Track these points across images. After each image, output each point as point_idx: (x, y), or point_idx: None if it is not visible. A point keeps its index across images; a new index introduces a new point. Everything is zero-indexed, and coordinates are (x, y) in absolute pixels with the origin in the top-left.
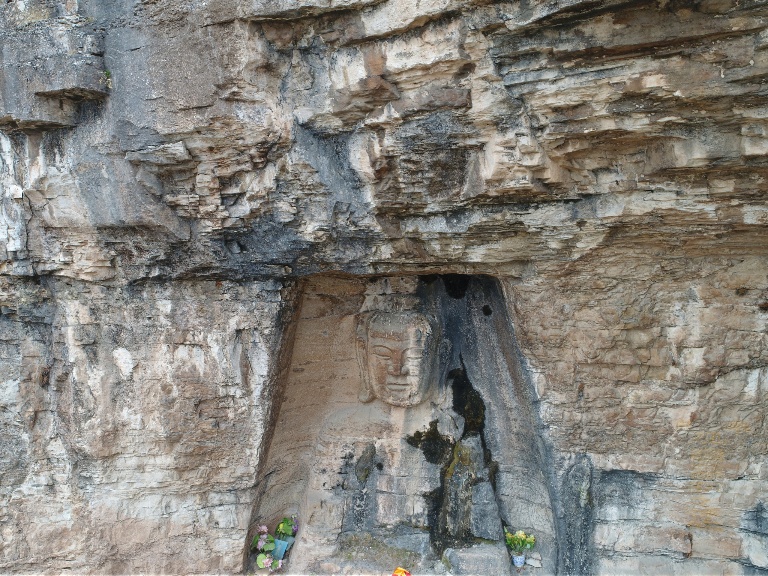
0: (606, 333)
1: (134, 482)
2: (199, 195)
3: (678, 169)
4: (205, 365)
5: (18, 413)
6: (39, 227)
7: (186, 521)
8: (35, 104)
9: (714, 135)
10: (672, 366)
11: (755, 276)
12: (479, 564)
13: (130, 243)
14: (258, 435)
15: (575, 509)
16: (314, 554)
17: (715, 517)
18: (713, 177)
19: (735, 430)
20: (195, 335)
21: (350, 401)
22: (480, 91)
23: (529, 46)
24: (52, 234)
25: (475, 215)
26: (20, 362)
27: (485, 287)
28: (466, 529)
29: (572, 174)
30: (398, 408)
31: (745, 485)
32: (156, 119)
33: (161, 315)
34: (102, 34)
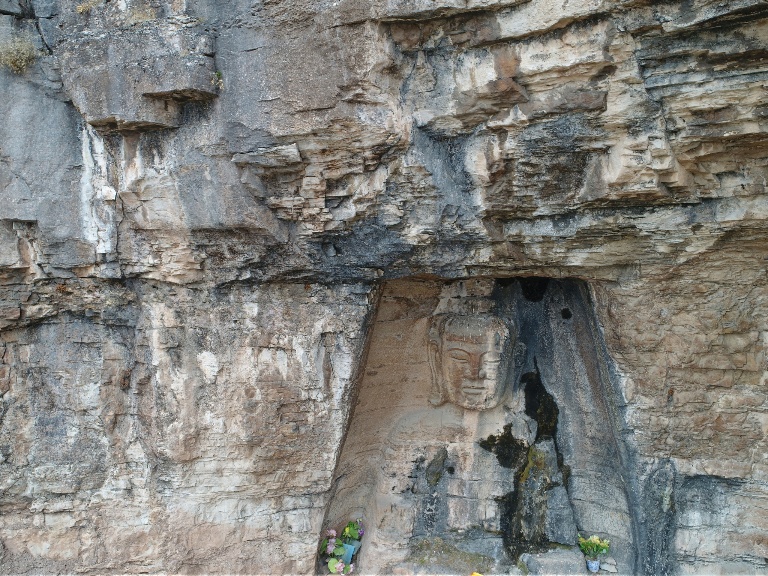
0: (703, 338)
1: (212, 486)
2: (303, 198)
3: None
4: (288, 368)
5: (98, 416)
6: (130, 229)
7: (260, 525)
8: (142, 105)
9: None
10: (767, 371)
11: None
12: (558, 569)
13: (224, 246)
14: (336, 439)
15: (657, 514)
16: (386, 559)
17: None
18: None
19: None
20: (280, 338)
21: (420, 404)
22: (618, 94)
23: (682, 48)
24: (142, 236)
25: (585, 219)
26: (101, 365)
27: (566, 290)
28: (541, 534)
29: (696, 178)
30: (471, 412)
31: None
32: (270, 121)
33: (247, 318)
34: (214, 34)
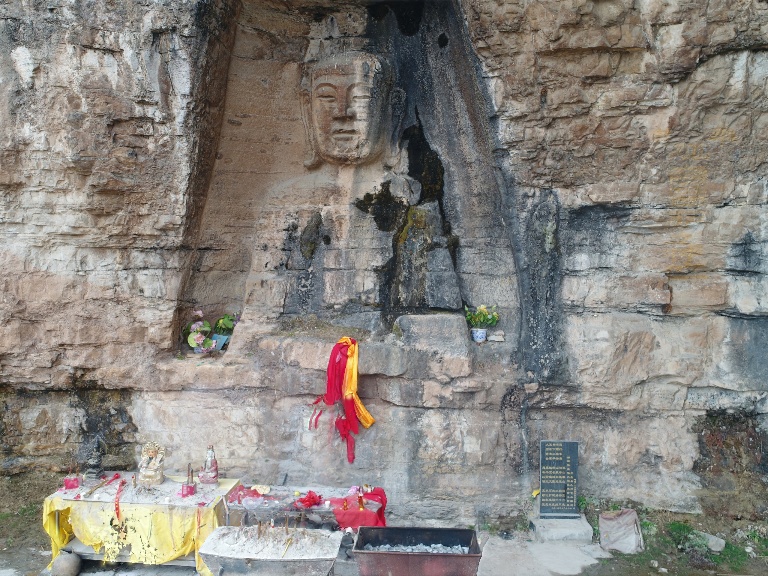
0: (570, 4)
1: (43, 225)
2: None
3: None
4: (118, 78)
5: None
6: None
7: (105, 283)
8: None
9: None
10: (647, 52)
11: None
12: (432, 326)
13: None
14: (183, 175)
15: (540, 256)
16: (251, 331)
17: (697, 256)
18: None
19: (720, 140)
20: (105, 36)
21: (296, 172)
22: None
23: None
24: None
25: None
26: None
27: (440, 10)
28: (420, 298)
29: None
30: (346, 168)
31: (731, 214)
32: None
33: (64, 6)
34: None
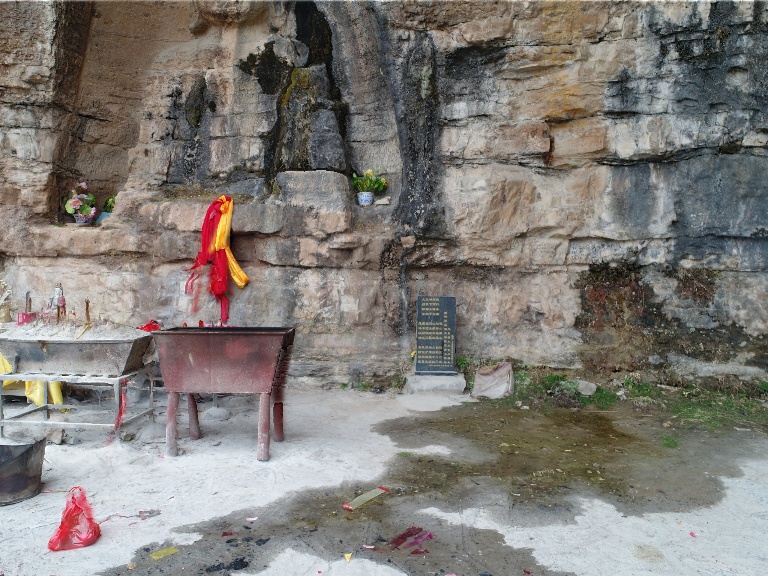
0: None
1: None
2: None
3: None
4: None
5: None
6: None
7: None
8: None
9: None
10: None
11: None
12: (309, 181)
13: None
14: (49, 22)
15: (416, 103)
16: (131, 197)
17: (575, 98)
18: None
19: None
20: None
21: (183, 40)
22: None
23: None
24: None
25: None
26: None
27: None
28: (303, 160)
29: None
30: (229, 28)
31: (607, 50)
32: None
33: None
34: None
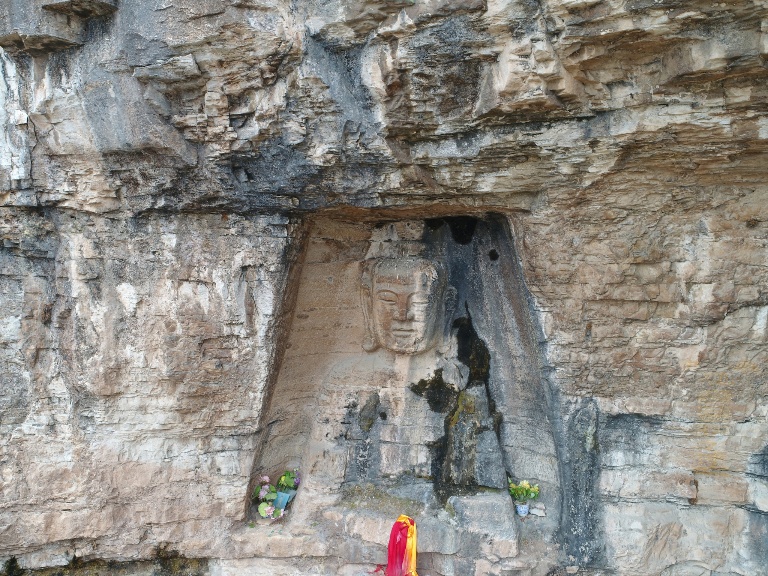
0: (615, 267)
1: (136, 424)
2: (207, 116)
3: (695, 75)
4: (209, 303)
5: (19, 350)
6: (43, 155)
7: (188, 466)
8: (42, 18)
9: (733, 33)
10: (681, 303)
11: (766, 207)
12: (483, 510)
13: (136, 170)
14: (262, 378)
15: (581, 454)
16: (316, 503)
17: (721, 461)
18: (730, 84)
19: (743, 370)
20: (200, 271)
21: (354, 351)
22: None
23: None
24: (57, 163)
25: (486, 137)
26: (22, 298)
27: (492, 231)
28: (470, 477)
29: (586, 88)
30: (403, 356)
31: (752, 428)
32: (166, 30)
33: (166, 249)
34: None
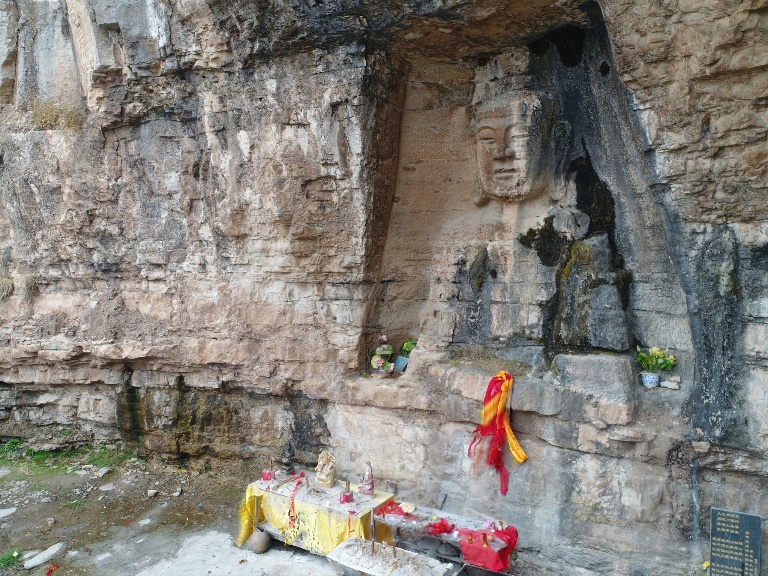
0: (726, 22)
1: (262, 266)
2: None
3: None
4: (309, 145)
5: (179, 200)
6: (178, 22)
7: (307, 311)
8: None
9: None
10: None
11: None
12: (588, 368)
13: (233, 16)
14: (361, 222)
15: (712, 299)
16: (423, 358)
17: None
18: None
19: None
20: (298, 114)
21: (467, 209)
22: None
23: None
24: (187, 27)
25: None
26: (180, 156)
27: (600, 38)
28: (582, 337)
29: None
30: (510, 205)
31: None
32: None
33: (269, 95)
34: None
